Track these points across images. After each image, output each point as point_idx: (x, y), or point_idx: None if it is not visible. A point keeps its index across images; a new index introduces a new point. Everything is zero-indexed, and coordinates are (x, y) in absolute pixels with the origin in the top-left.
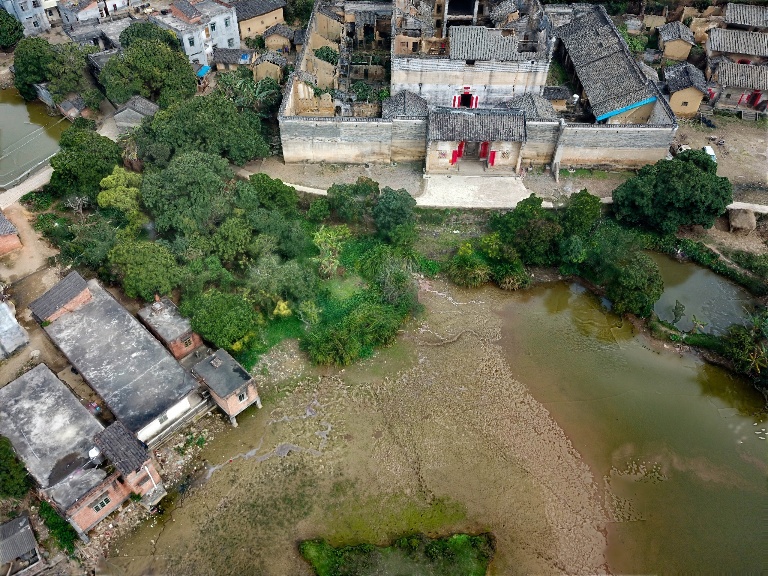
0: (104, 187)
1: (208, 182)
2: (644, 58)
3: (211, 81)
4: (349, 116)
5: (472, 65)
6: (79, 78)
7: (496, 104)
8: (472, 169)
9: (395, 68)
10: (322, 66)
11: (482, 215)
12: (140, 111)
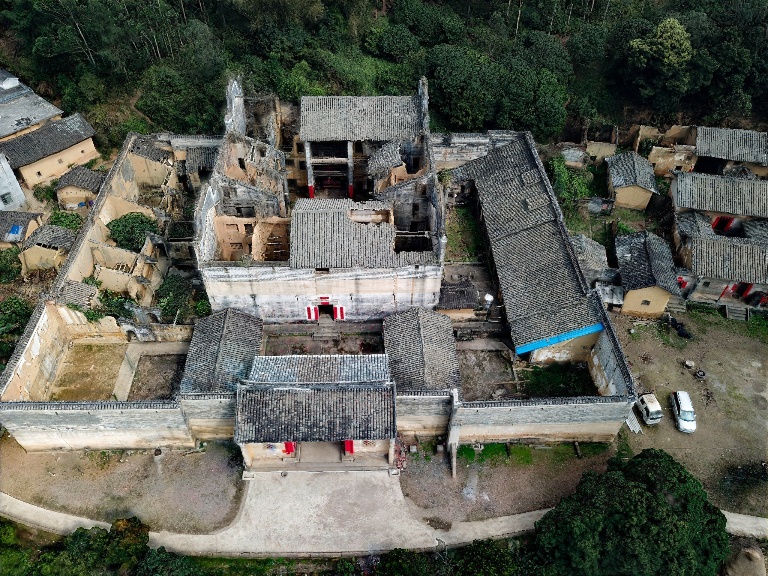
0: None
1: None
2: (588, 208)
3: None
4: (151, 340)
5: (326, 271)
6: None
7: (372, 314)
8: (322, 456)
9: (209, 278)
10: (117, 254)
11: (327, 564)
12: None
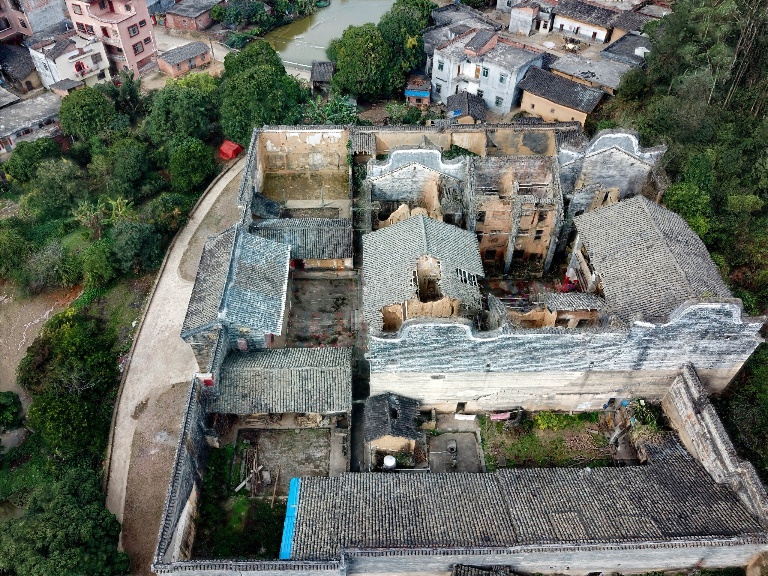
0: None
1: None
2: None
3: None
4: None
5: None
6: None
7: None
8: None
9: None
10: None
11: None
12: (314, 71)
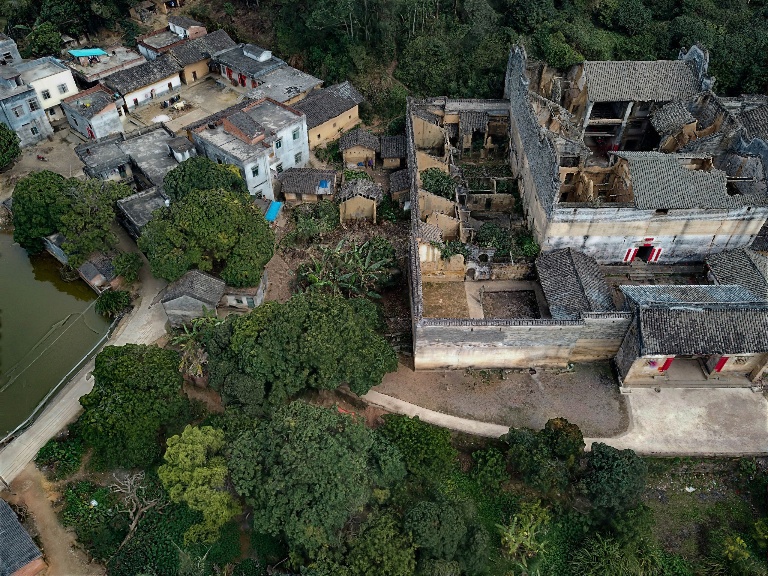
0: (171, 462)
1: (343, 470)
2: None
3: (279, 217)
4: (484, 279)
5: (663, 213)
6: (105, 233)
7: (684, 256)
8: (686, 375)
9: (555, 219)
10: (437, 203)
11: (727, 464)
12: (202, 297)
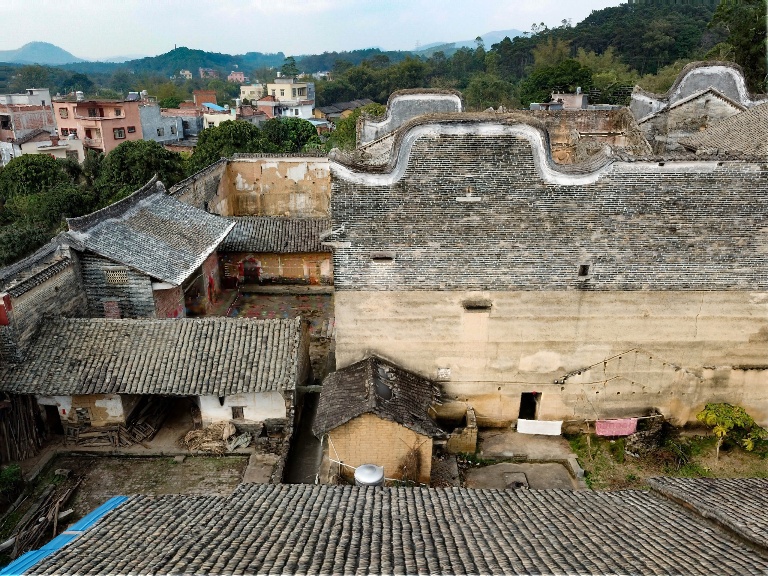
0: None
1: None
2: None
3: None
4: None
5: None
6: None
7: None
8: None
9: None
10: None
11: None
12: None
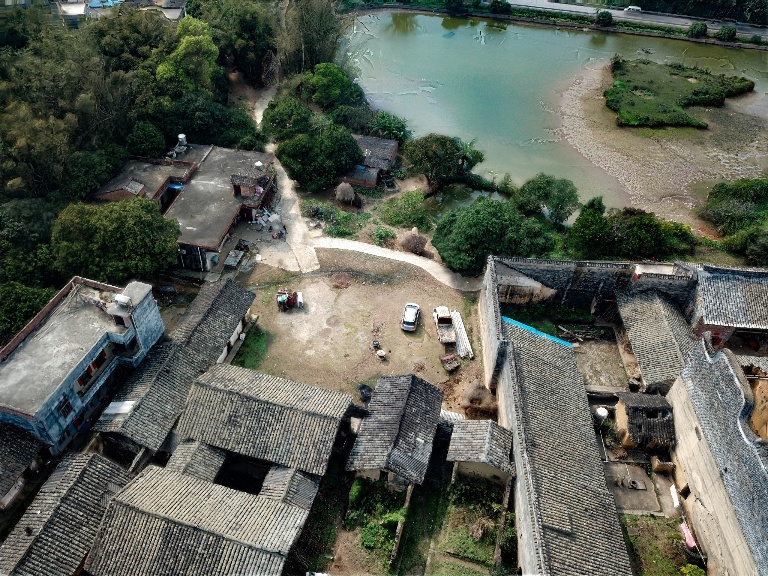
0: None
1: None
2: None
3: None
4: None
5: None
6: None
7: None
8: None
9: None
10: None
11: None
12: None
